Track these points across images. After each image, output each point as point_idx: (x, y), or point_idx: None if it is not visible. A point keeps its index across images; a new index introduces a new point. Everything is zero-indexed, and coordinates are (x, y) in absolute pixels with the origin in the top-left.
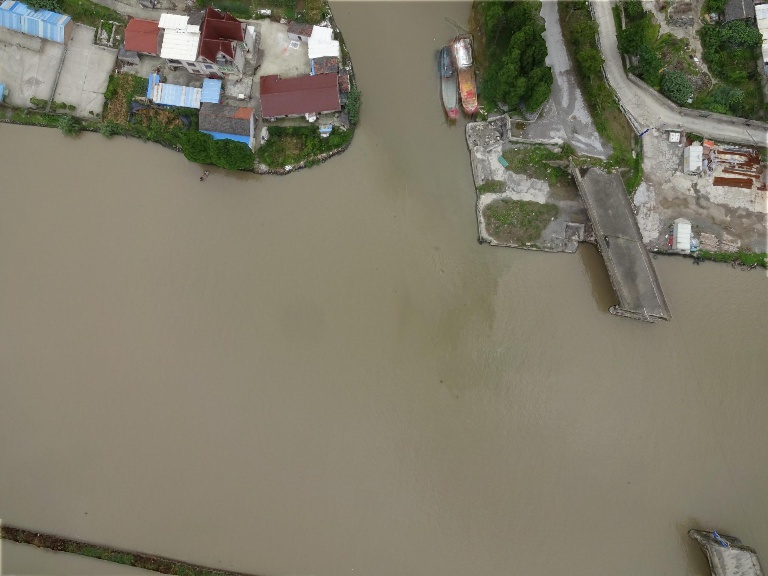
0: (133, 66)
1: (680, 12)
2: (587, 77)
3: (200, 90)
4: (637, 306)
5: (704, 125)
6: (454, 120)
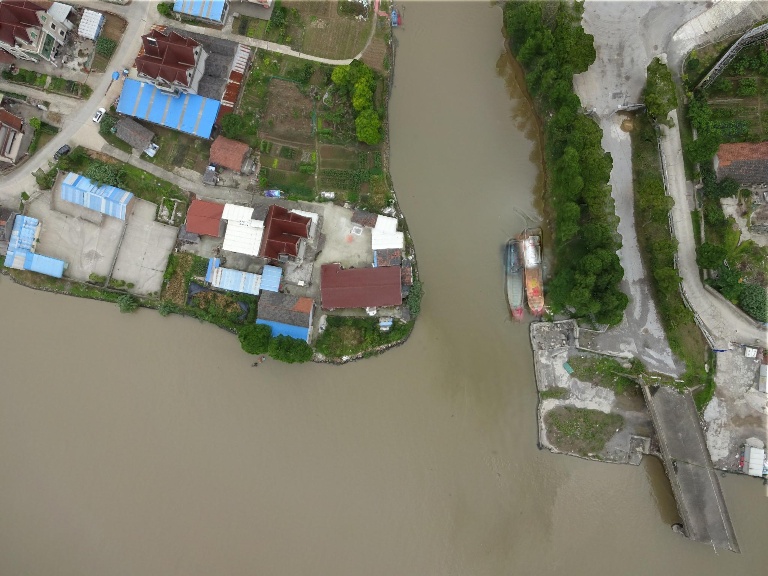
0: (193, 245)
1: (763, 218)
2: (662, 291)
3: (260, 277)
4: (704, 537)
5: None
6: (518, 317)
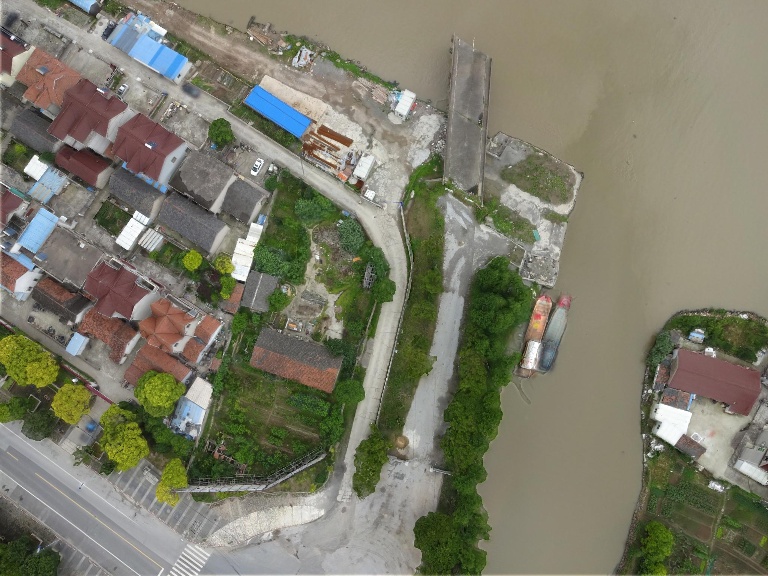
0: None
1: (310, 309)
2: None
3: None
4: (479, 55)
5: (339, 195)
6: None
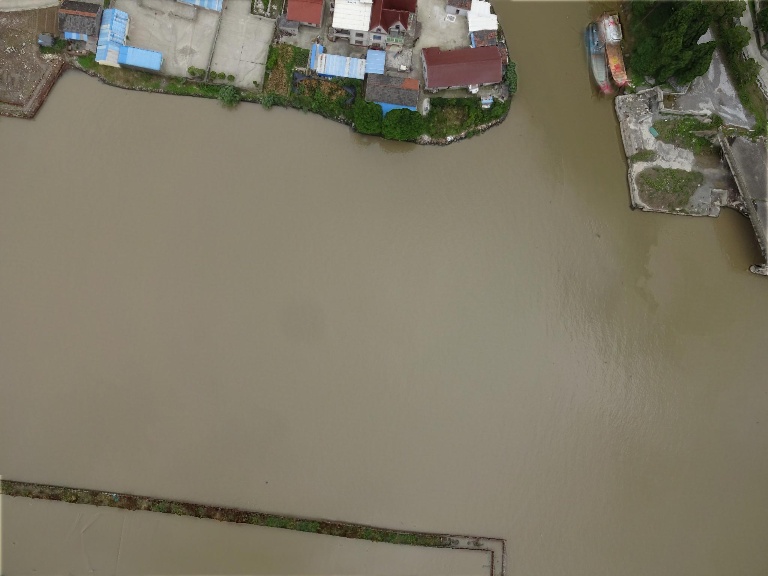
0: (291, 36)
1: None
2: (732, 52)
3: (364, 61)
4: None
5: None
6: (603, 93)
